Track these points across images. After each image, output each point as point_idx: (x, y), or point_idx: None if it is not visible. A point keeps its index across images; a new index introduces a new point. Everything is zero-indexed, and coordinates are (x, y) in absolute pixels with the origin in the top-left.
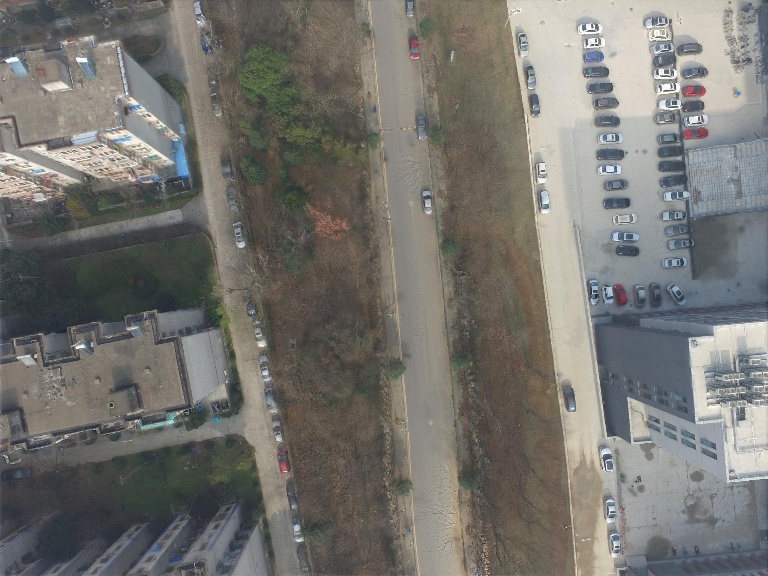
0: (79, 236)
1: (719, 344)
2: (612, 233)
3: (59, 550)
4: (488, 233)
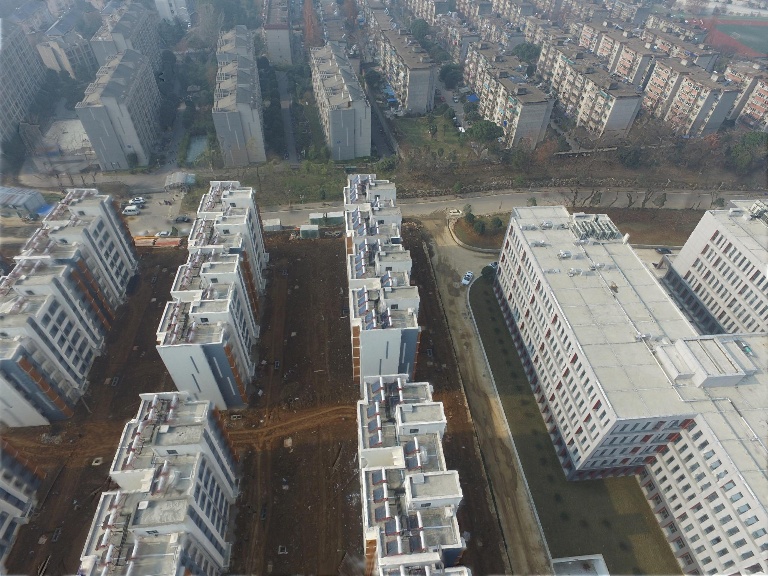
0: None
1: None
2: None
3: None
4: None
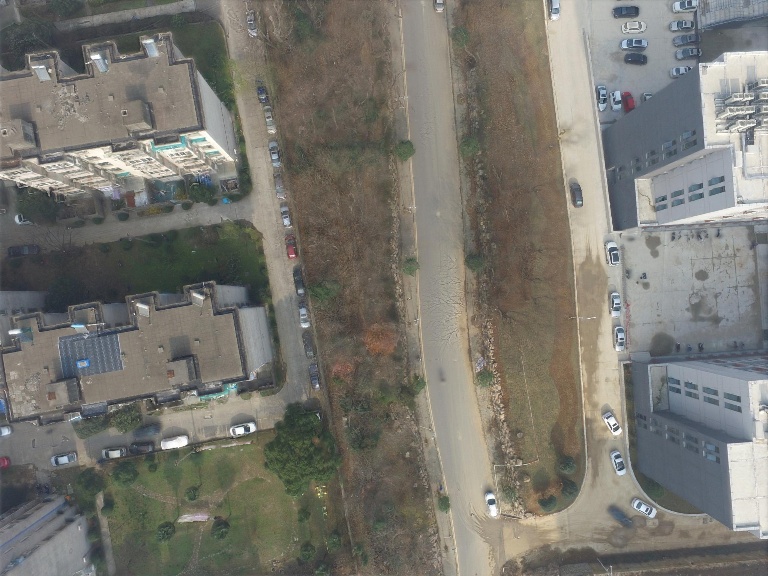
0: (92, 23)
1: (729, 72)
2: (621, 41)
3: (66, 298)
4: (499, 28)
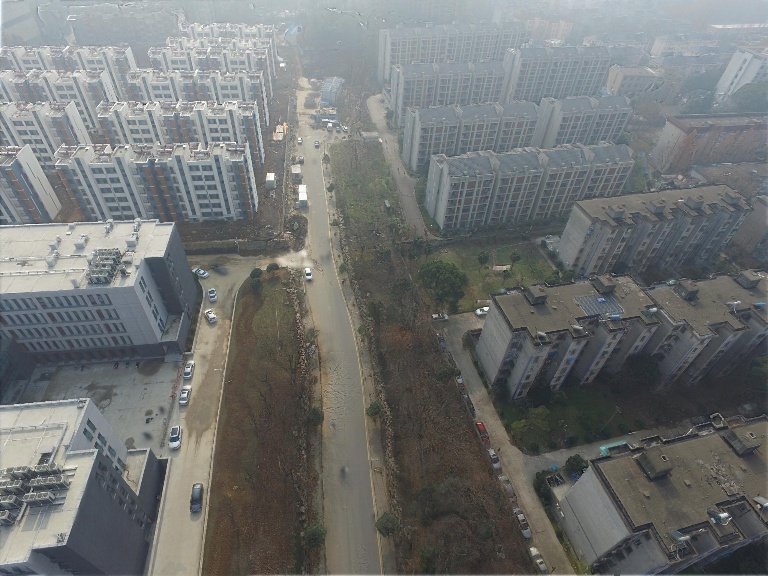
0: None
1: (30, 539)
2: None
3: (641, 360)
4: None
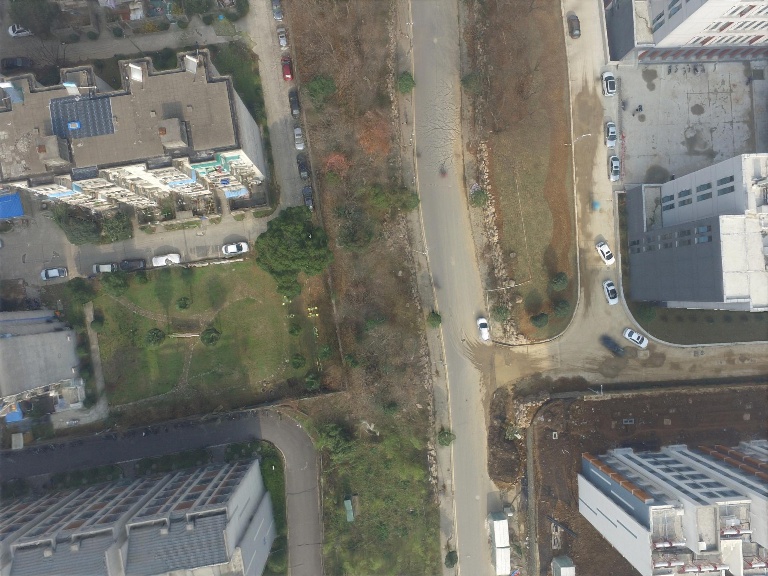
0: None
1: None
2: None
3: None
4: None
